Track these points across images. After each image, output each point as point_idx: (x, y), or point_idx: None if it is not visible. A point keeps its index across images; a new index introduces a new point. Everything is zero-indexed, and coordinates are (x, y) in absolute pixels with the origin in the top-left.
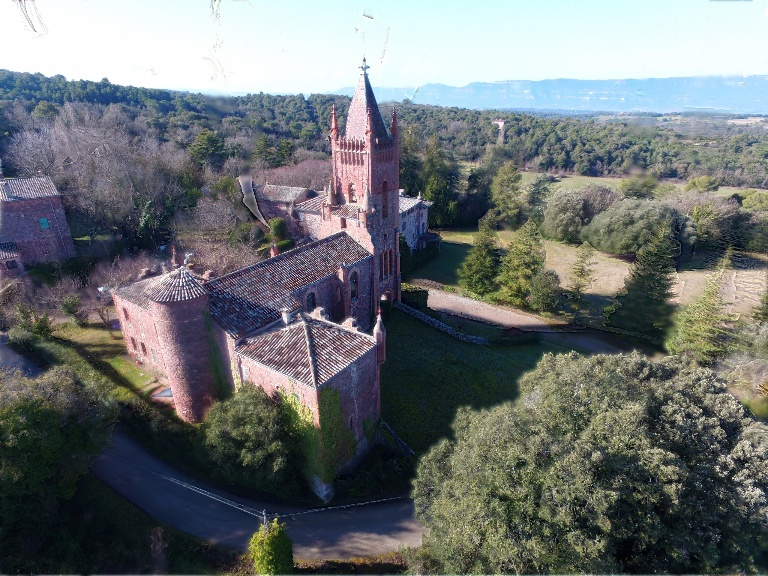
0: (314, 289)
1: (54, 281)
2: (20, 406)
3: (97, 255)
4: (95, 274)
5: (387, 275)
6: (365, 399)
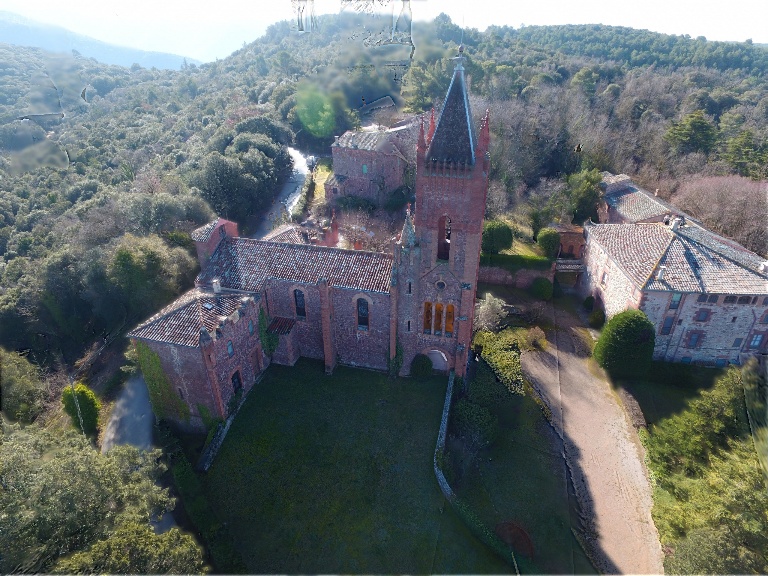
0: (303, 288)
1: (347, 210)
2: (119, 252)
3: (375, 203)
4: (374, 216)
5: (441, 332)
6: (197, 387)
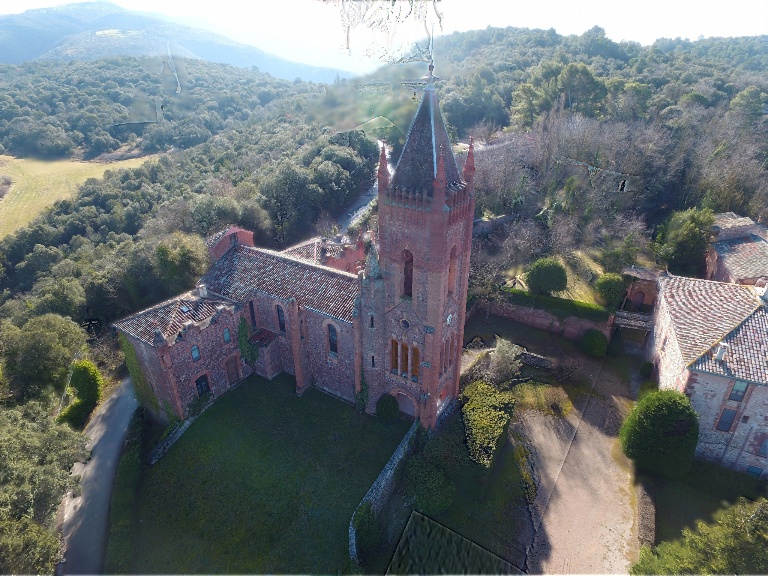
0: (282, 304)
1: None
2: (159, 247)
3: None
4: None
5: (408, 375)
6: None
